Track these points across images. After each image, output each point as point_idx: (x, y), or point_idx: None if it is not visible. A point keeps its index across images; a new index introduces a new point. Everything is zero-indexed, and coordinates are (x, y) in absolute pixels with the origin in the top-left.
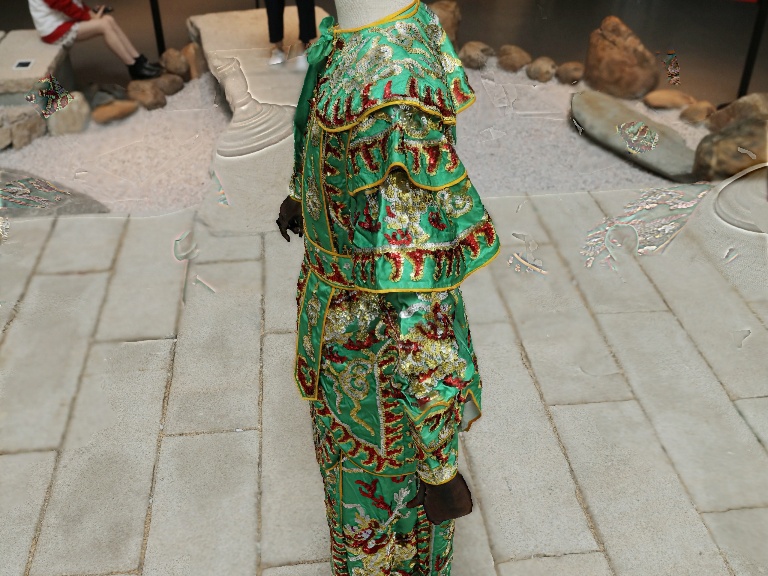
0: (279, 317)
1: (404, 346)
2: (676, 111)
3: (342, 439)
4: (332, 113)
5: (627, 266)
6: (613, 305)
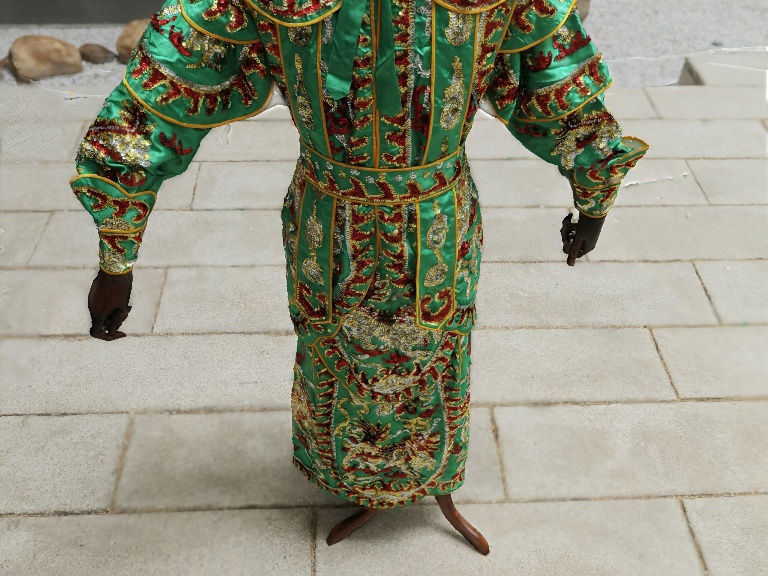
0: None
1: None
2: None
3: None
4: None
5: None
6: (21, 248)
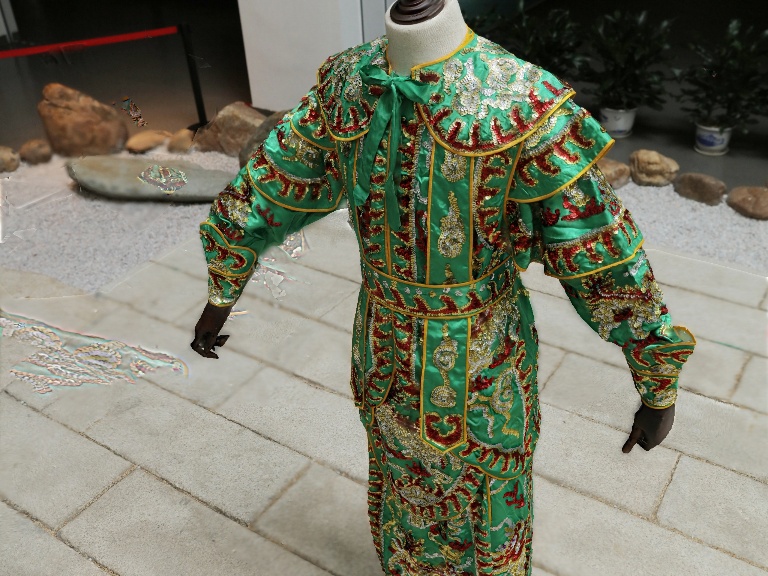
0: (52, 506)
1: (647, 296)
2: (161, 148)
3: (493, 462)
4: (493, 134)
5: (298, 272)
6: (323, 305)
